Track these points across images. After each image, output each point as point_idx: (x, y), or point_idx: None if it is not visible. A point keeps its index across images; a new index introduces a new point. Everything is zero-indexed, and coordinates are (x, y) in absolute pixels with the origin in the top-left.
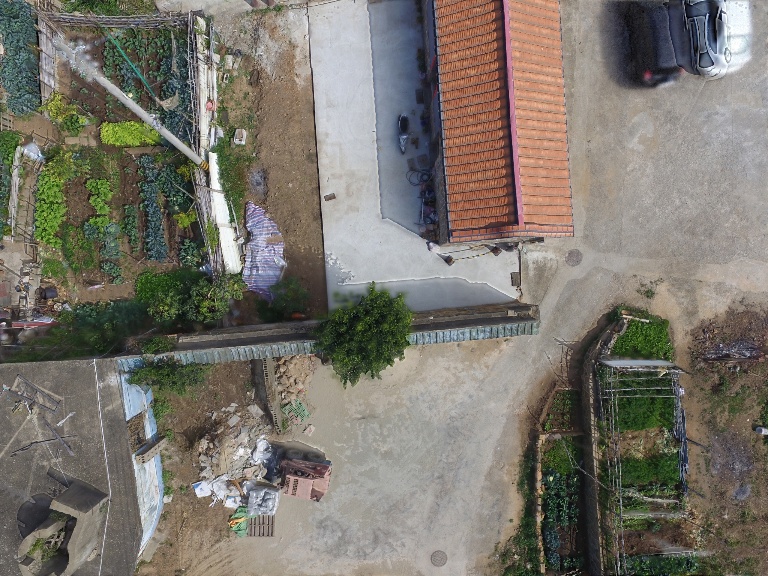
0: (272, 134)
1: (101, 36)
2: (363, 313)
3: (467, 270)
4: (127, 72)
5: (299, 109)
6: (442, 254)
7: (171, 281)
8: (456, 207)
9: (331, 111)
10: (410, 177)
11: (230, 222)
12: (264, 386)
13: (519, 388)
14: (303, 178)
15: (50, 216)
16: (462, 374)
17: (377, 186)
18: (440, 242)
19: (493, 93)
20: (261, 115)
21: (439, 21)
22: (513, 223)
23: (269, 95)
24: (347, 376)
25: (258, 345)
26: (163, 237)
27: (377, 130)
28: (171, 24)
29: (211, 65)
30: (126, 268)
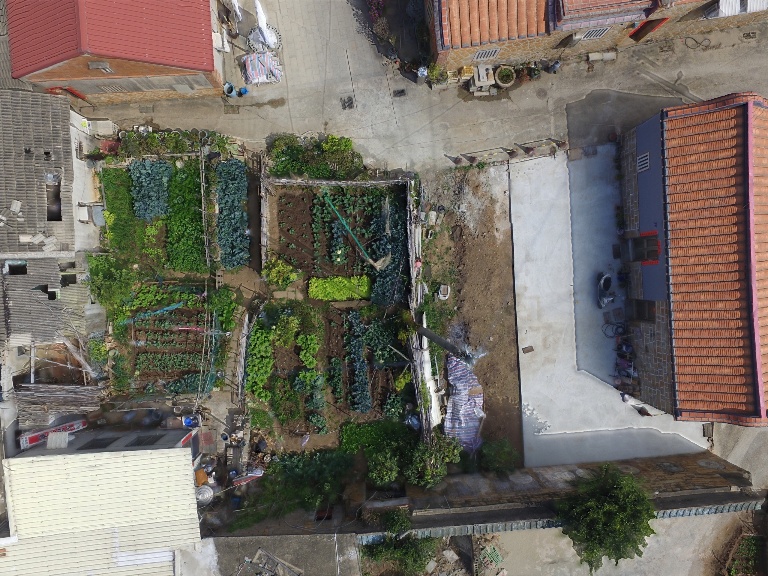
0: (475, 290)
1: (310, 193)
2: (615, 507)
3: (660, 421)
4: (338, 231)
5: (498, 263)
6: (635, 405)
7: (385, 440)
8: (685, 388)
9: (530, 265)
10: (605, 330)
11: (432, 375)
12: (470, 539)
13: (705, 533)
14: (501, 330)
15: (261, 371)
16: (650, 520)
17: (573, 338)
18: (640, 398)
19: (731, 284)
20: (463, 270)
21: (672, 207)
22: (752, 413)
23: (472, 251)
24: (593, 563)
25: (495, 523)
26: (367, 389)
27: (574, 284)
28: (382, 185)
29: (419, 224)
30: (330, 418)
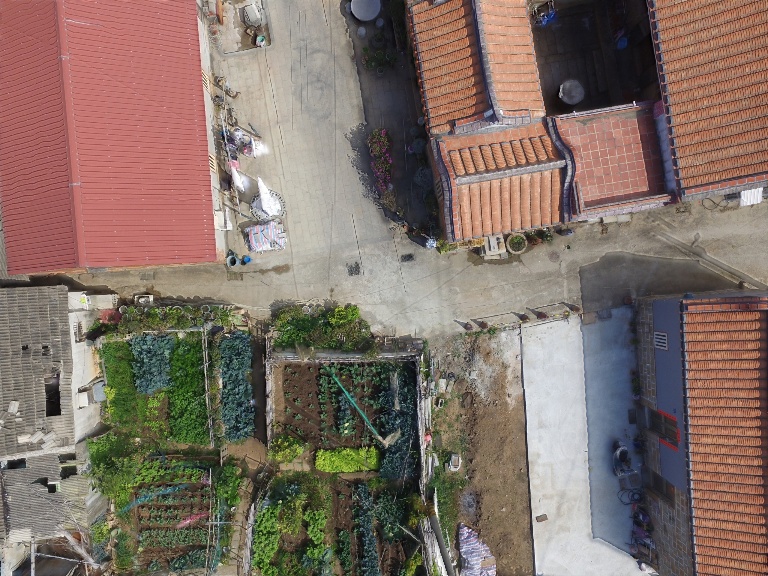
0: (487, 460)
1: None
2: None
3: None
4: (345, 404)
5: (510, 429)
6: (653, 573)
7: None
8: None
9: (543, 432)
10: (621, 496)
11: None
12: None
13: None
14: (514, 498)
15: (268, 548)
16: None
17: (588, 505)
18: (658, 572)
19: (755, 488)
20: (475, 439)
21: (692, 402)
22: None
23: (484, 420)
24: None
25: None
26: (377, 562)
27: (589, 450)
28: None
29: (429, 395)
30: None
